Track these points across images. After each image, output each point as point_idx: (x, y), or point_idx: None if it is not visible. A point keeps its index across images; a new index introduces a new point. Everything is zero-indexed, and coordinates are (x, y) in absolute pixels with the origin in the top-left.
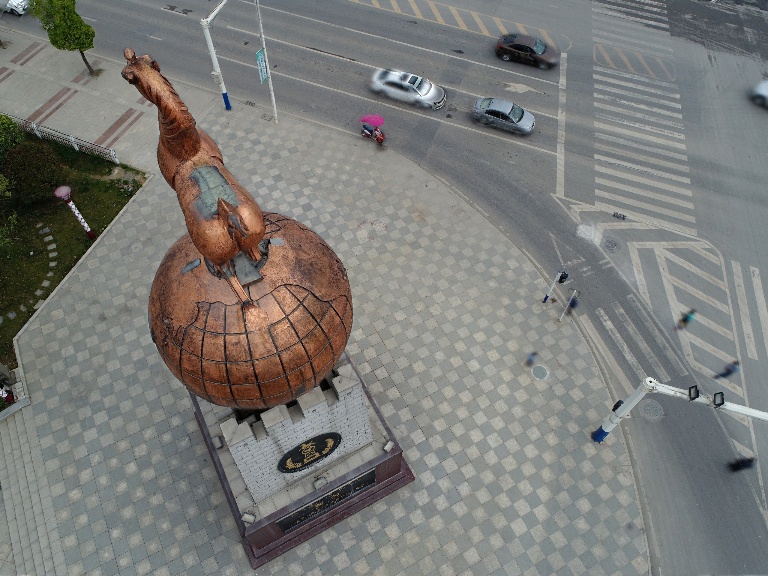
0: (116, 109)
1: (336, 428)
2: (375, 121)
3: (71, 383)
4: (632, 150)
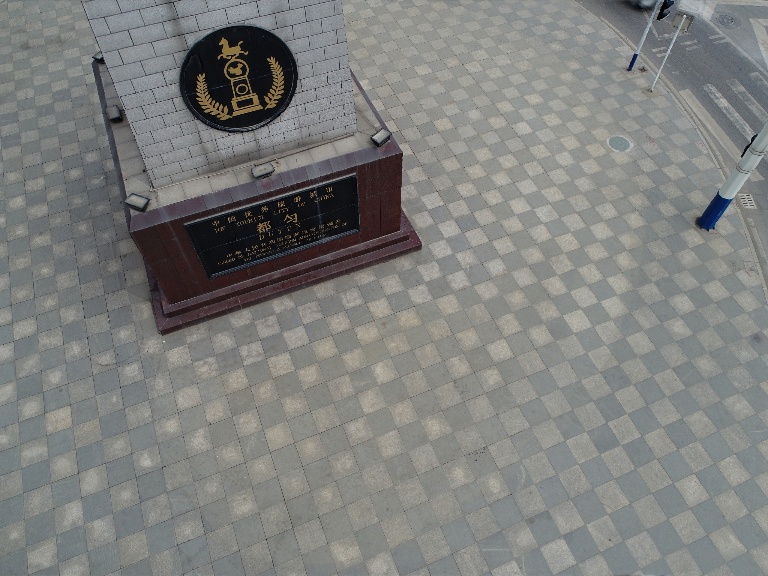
0: None
1: (285, 29)
2: None
3: None
4: None
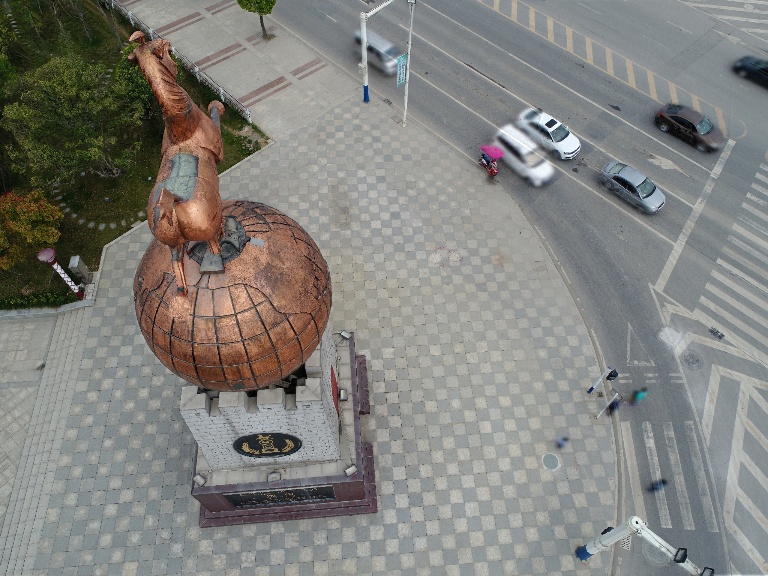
0: (270, 74)
1: (296, 433)
2: (493, 153)
3: (131, 300)
4: (765, 267)
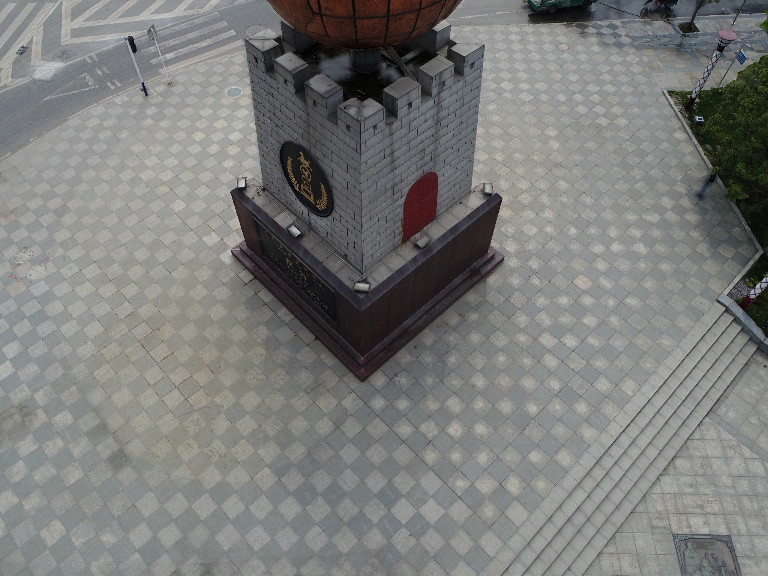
0: None
1: None
2: None
3: None
4: None
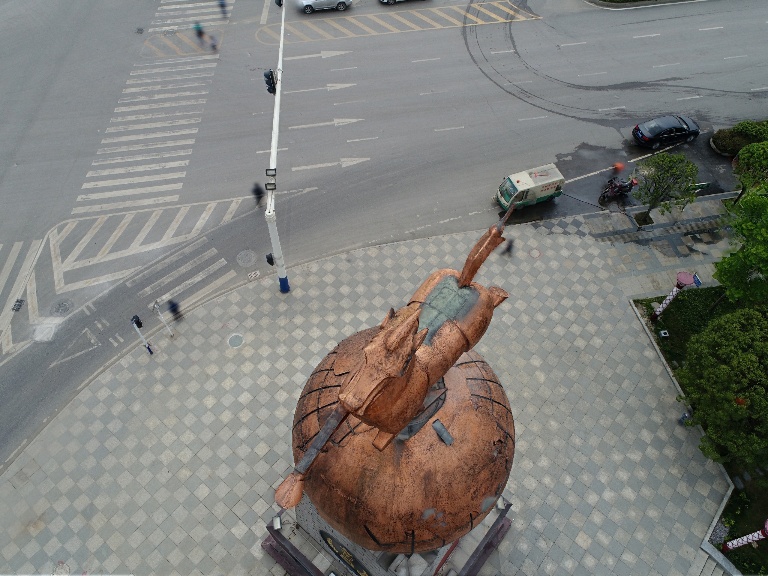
0: None
1: None
2: None
3: None
4: None
